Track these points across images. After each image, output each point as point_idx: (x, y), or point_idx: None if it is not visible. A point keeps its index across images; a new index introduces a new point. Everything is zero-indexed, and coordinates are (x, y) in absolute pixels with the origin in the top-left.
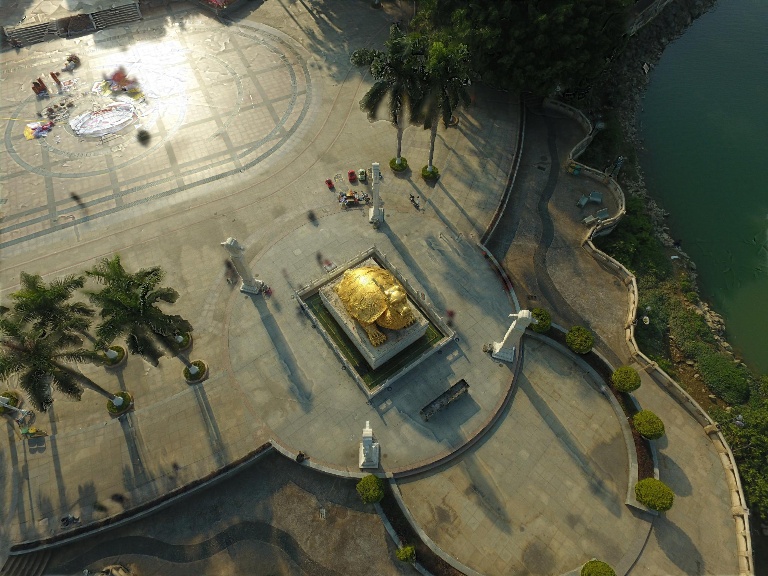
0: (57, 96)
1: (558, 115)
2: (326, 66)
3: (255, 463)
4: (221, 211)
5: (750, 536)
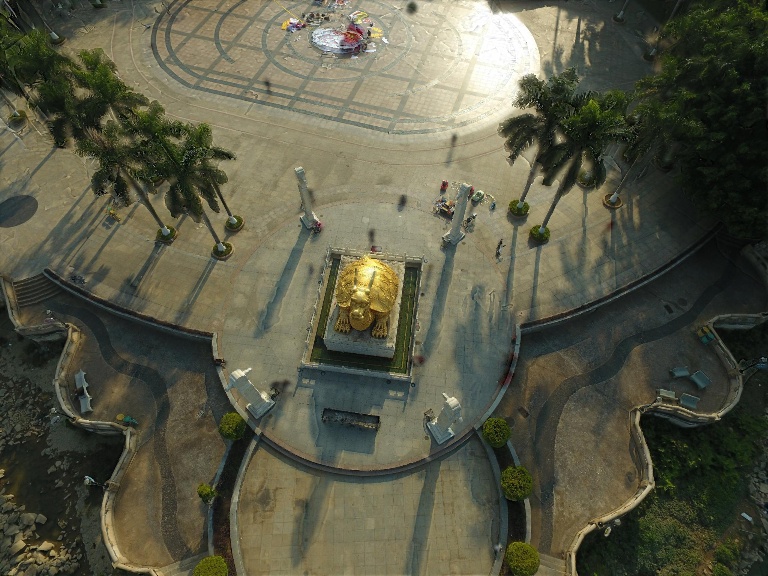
0: (326, 8)
1: (751, 272)
2: None
3: (197, 341)
4: (346, 153)
5: None
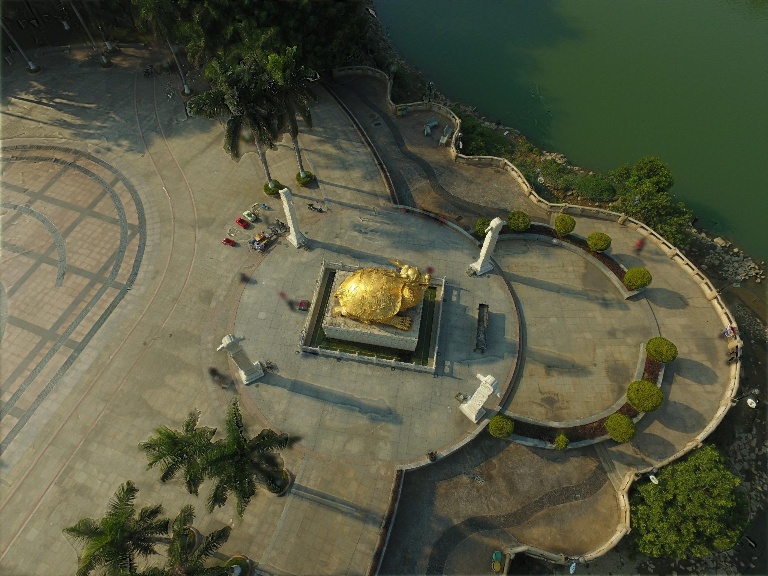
0: None
1: (351, 78)
2: (113, 145)
3: None
4: (148, 337)
5: (689, 261)
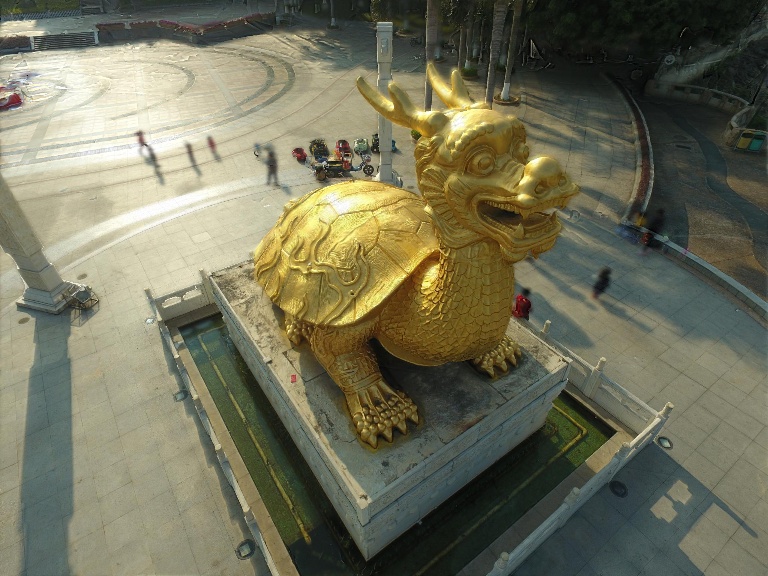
0: None
1: (673, 102)
2: (319, 67)
3: None
4: (77, 187)
5: None
